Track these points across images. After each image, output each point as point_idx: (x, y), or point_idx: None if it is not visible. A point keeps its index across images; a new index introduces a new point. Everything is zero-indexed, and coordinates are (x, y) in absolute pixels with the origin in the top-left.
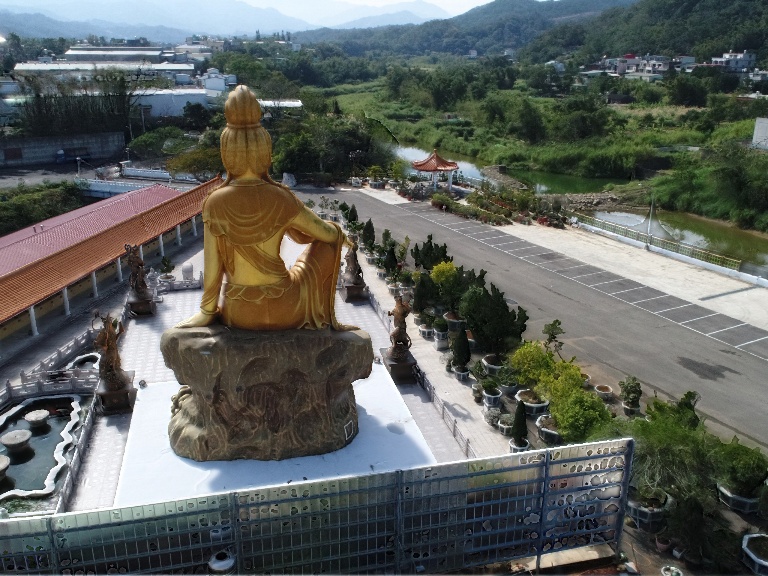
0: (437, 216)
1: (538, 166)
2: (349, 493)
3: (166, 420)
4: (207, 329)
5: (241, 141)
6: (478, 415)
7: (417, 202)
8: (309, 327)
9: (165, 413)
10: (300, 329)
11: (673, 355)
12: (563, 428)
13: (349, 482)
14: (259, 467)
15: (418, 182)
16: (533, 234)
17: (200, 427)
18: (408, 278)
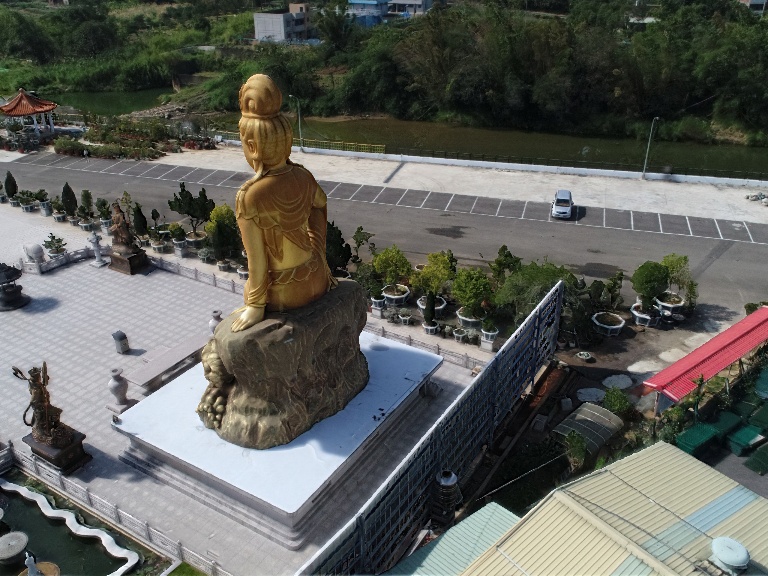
0: (80, 164)
1: (70, 87)
2: (478, 388)
3: (198, 433)
4: (273, 320)
5: (281, 130)
6: (373, 320)
7: (34, 153)
8: (333, 287)
9: (186, 429)
10: (330, 291)
11: (421, 229)
12: (467, 299)
13: (478, 380)
14: (336, 421)
15: (9, 130)
16: (197, 160)
17: (275, 414)
18: (182, 231)
